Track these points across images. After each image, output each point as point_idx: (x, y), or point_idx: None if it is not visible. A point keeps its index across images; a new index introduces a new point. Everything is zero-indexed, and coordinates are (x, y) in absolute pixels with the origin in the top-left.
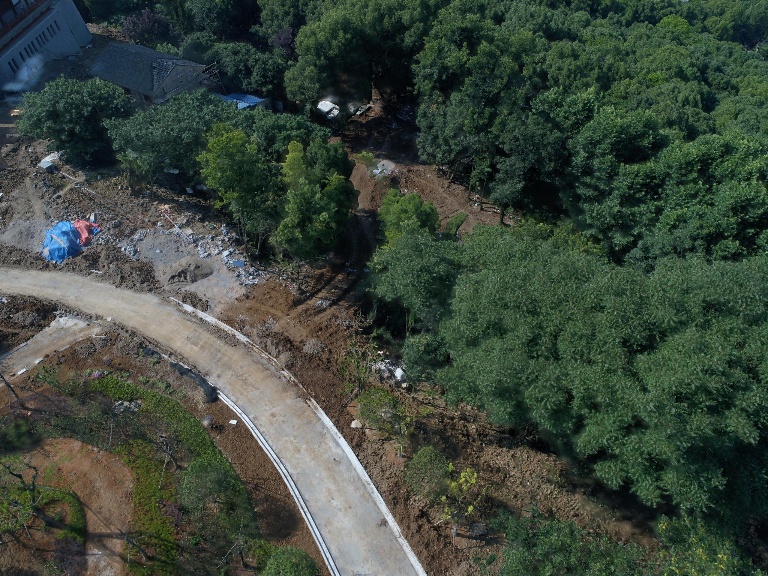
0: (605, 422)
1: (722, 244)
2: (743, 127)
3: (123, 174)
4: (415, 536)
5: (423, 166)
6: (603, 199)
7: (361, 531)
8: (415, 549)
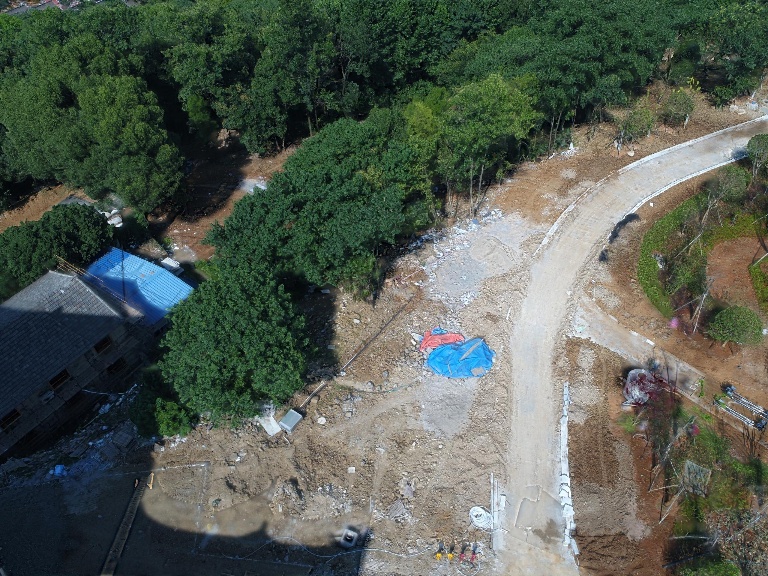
0: (685, 6)
1: (475, 2)
2: (261, 8)
3: (360, 297)
4: (695, 134)
5: (253, 164)
6: (392, 47)
7: (700, 154)
8: (702, 135)
